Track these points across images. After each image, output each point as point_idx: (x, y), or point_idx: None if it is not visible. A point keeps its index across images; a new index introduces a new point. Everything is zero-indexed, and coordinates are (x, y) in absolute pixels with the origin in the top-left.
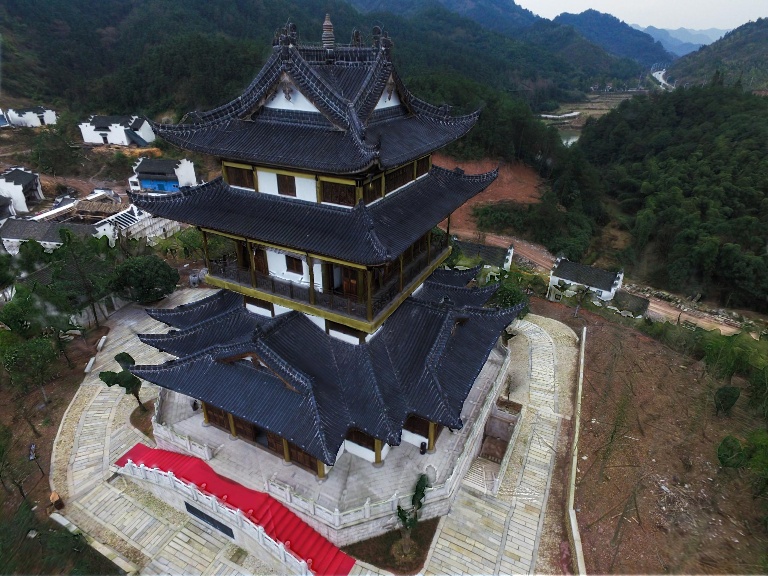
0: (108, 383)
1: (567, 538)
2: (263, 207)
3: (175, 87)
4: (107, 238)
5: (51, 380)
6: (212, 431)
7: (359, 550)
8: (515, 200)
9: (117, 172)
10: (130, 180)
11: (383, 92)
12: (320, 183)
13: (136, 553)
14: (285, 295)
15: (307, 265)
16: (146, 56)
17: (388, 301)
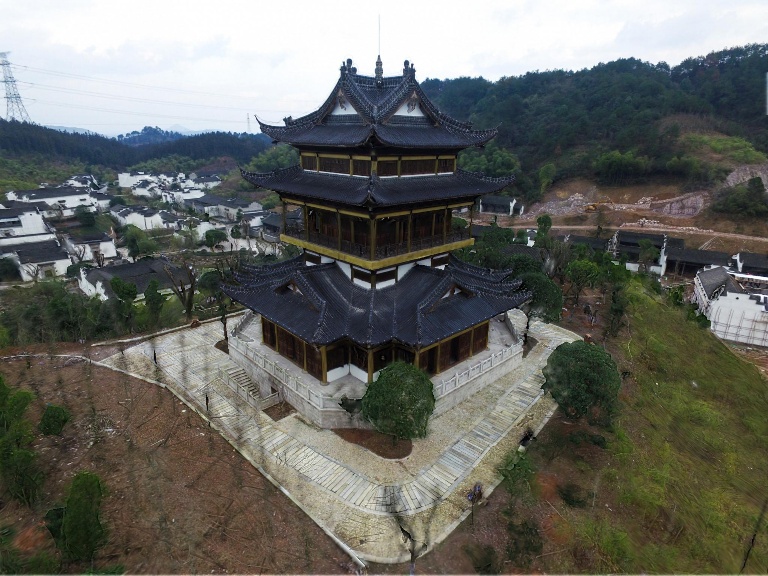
0: None
1: None
2: None
3: None
4: (621, 268)
5: None
6: None
7: None
8: None
9: None
10: None
11: None
12: None
13: None
14: None
15: None
16: None
17: (298, 237)
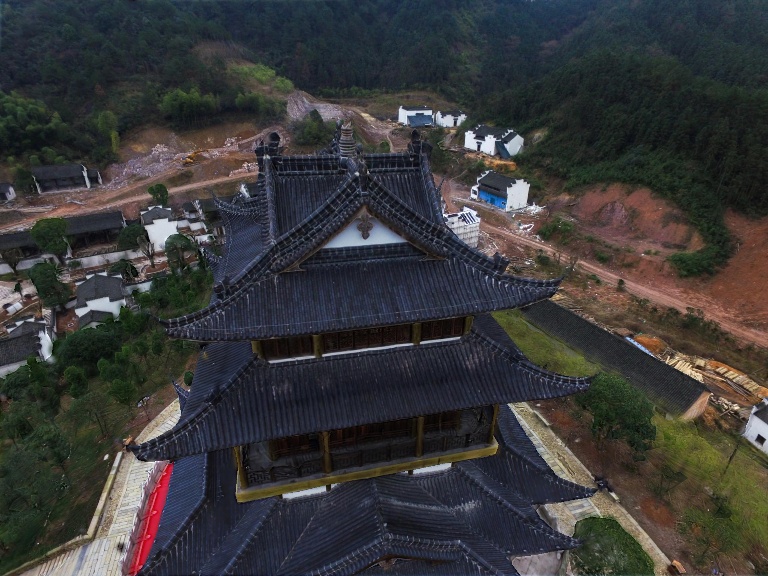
0: (186, 383)
1: None
2: None
3: (558, 106)
4: None
5: None
6: None
7: None
8: None
9: (472, 178)
10: (473, 188)
11: (352, 228)
12: None
13: (109, 523)
14: None
15: None
16: (551, 73)
17: (293, 475)
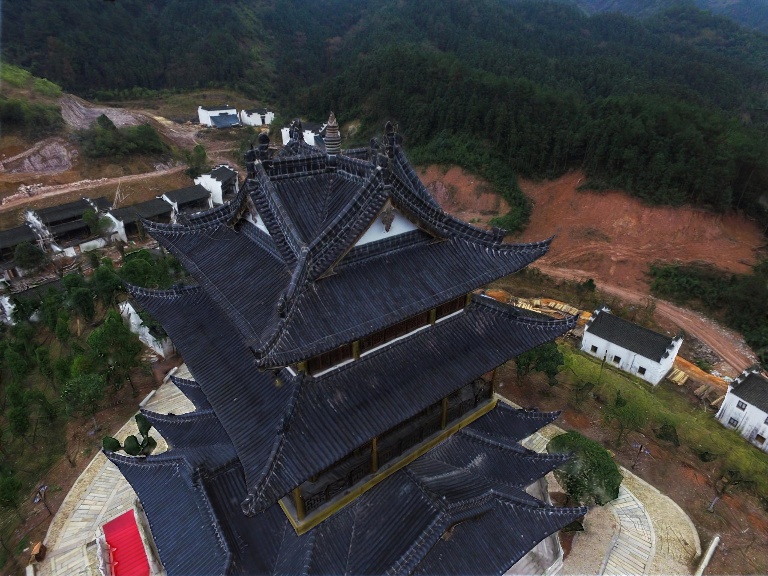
0: None
1: None
2: (228, 333)
3: (365, 98)
4: None
5: (115, 404)
6: None
7: None
8: (714, 265)
9: None
10: None
11: (376, 223)
12: None
13: None
14: None
15: None
16: None
17: (345, 487)
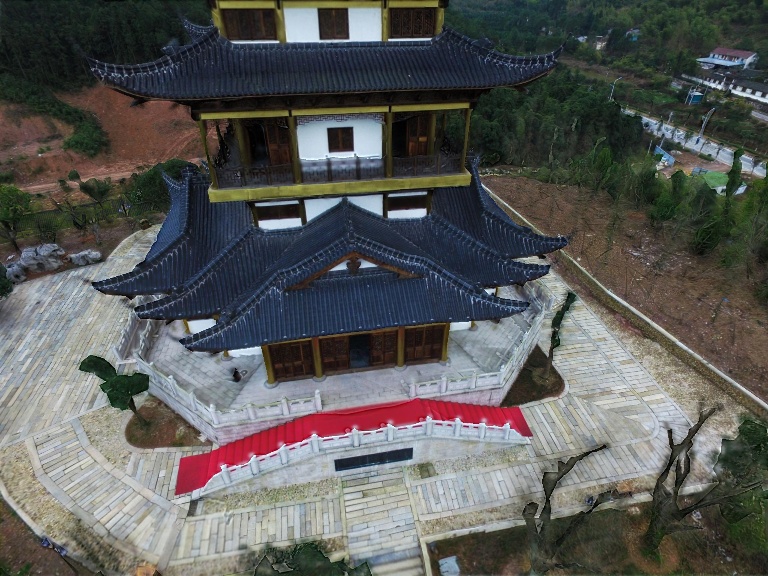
0: (126, 392)
1: (615, 311)
2: (309, 59)
3: None
4: None
5: None
6: (288, 386)
7: (514, 398)
8: None
9: None
10: None
11: None
12: (388, 12)
13: (321, 544)
14: (348, 178)
15: (362, 134)
16: None
17: (450, 156)
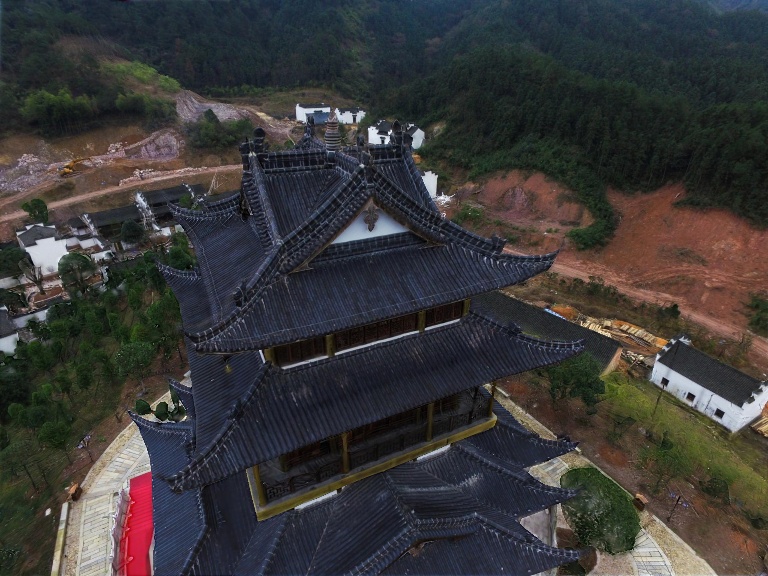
0: (138, 412)
1: None
2: None
3: (453, 100)
4: None
5: (165, 372)
6: None
7: None
8: None
9: None
10: None
11: (358, 221)
12: None
13: None
14: None
15: None
16: None
17: (312, 482)
